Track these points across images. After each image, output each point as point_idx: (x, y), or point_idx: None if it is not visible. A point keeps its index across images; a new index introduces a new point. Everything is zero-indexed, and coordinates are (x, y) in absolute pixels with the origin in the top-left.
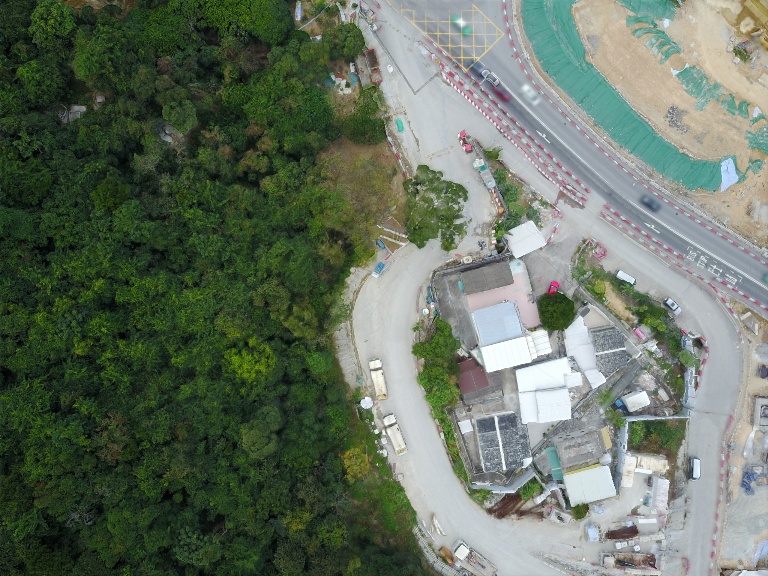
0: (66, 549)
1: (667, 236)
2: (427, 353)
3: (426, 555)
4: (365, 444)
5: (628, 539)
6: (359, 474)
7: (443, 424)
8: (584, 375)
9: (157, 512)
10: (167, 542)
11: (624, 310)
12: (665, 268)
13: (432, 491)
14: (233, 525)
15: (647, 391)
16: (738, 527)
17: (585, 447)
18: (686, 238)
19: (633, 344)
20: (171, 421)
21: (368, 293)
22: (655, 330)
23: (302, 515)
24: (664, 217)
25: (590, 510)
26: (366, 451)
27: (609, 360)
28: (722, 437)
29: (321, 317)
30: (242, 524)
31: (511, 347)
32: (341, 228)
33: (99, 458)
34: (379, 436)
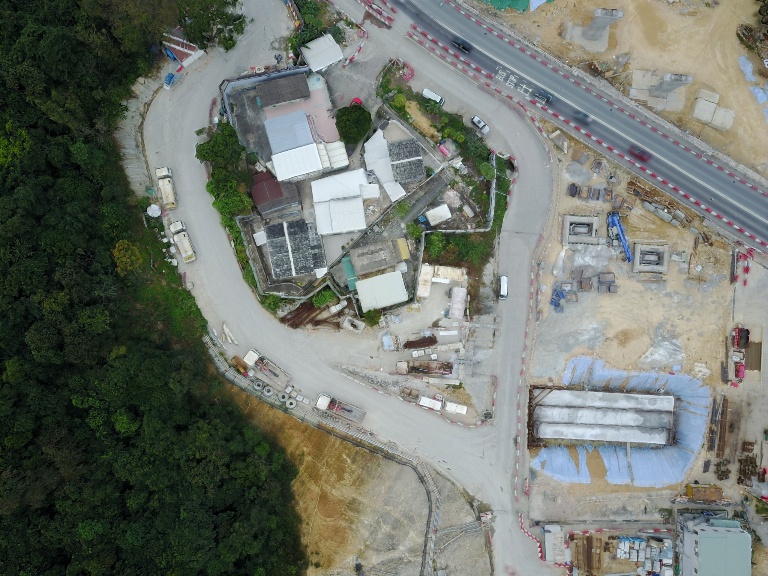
0: None
1: (476, 56)
2: (205, 152)
3: (217, 363)
4: (150, 250)
5: (425, 348)
6: (129, 267)
7: (231, 230)
8: (384, 188)
9: None
10: None
11: (429, 127)
12: (474, 88)
13: (223, 300)
14: None
15: (452, 207)
16: (548, 345)
17: (378, 254)
18: (495, 58)
19: (435, 158)
20: None
21: (160, 105)
22: (458, 145)
23: (57, 296)
24: (472, 37)
25: (389, 321)
26: (151, 257)
27: (405, 169)
28: (532, 256)
29: (91, 112)
30: None
31: (301, 154)
32: (100, 13)
33: None
34: (168, 245)
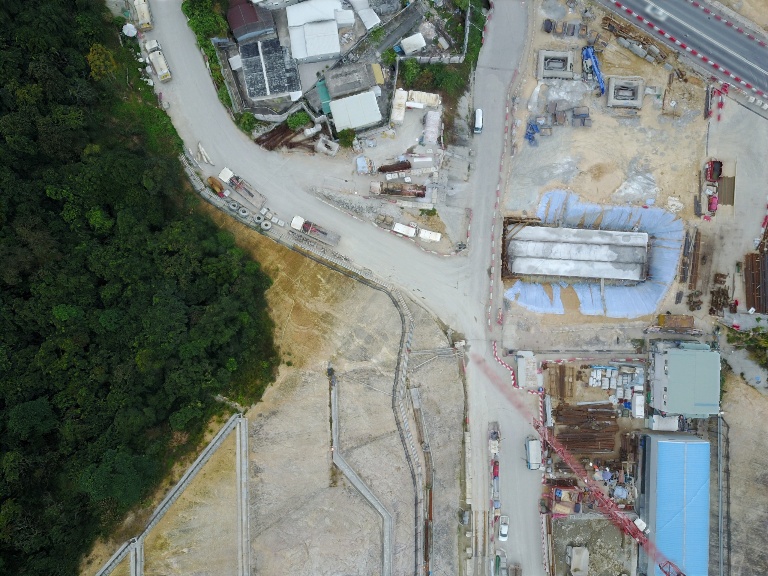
0: None
1: None
2: None
3: (192, 182)
4: (125, 66)
5: (399, 171)
6: (103, 71)
7: (205, 49)
8: (358, 16)
9: None
10: None
11: None
12: None
13: (199, 121)
14: None
15: (427, 39)
16: (522, 179)
17: (352, 76)
18: None
19: None
20: None
21: None
22: None
23: (30, 88)
24: None
25: (363, 146)
26: (127, 74)
27: None
28: (507, 91)
29: None
30: None
31: None
32: None
33: None
34: (144, 66)
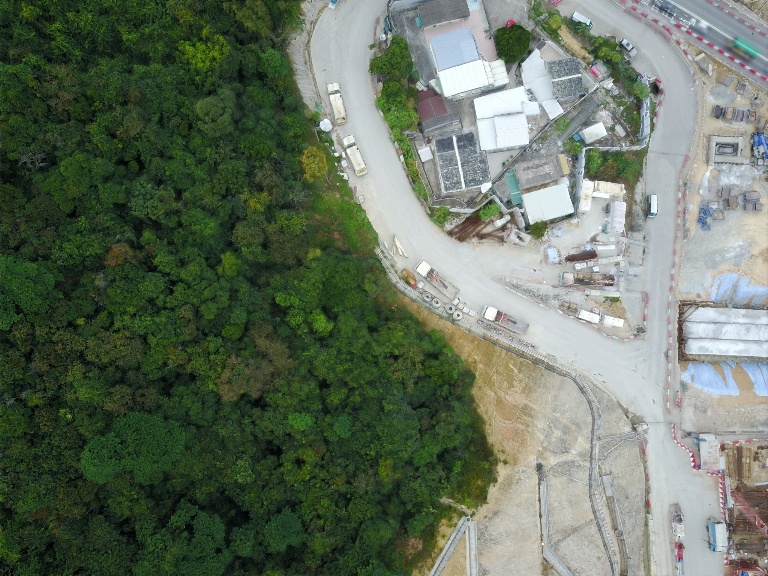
0: (19, 190)
1: None
2: (383, 64)
3: (389, 275)
4: None
5: (587, 260)
6: (317, 173)
7: (402, 144)
8: (541, 107)
9: (111, 166)
10: (122, 197)
11: (580, 49)
12: (620, 12)
13: (393, 214)
14: (190, 199)
15: None
16: (695, 262)
17: (543, 168)
18: None
19: (589, 78)
20: (123, 84)
21: (325, 24)
22: (611, 66)
23: (260, 196)
24: None
25: (550, 236)
26: None
27: (565, 86)
28: (678, 176)
29: (276, 22)
30: (199, 199)
31: (468, 70)
32: None
33: (50, 109)
34: (339, 160)
